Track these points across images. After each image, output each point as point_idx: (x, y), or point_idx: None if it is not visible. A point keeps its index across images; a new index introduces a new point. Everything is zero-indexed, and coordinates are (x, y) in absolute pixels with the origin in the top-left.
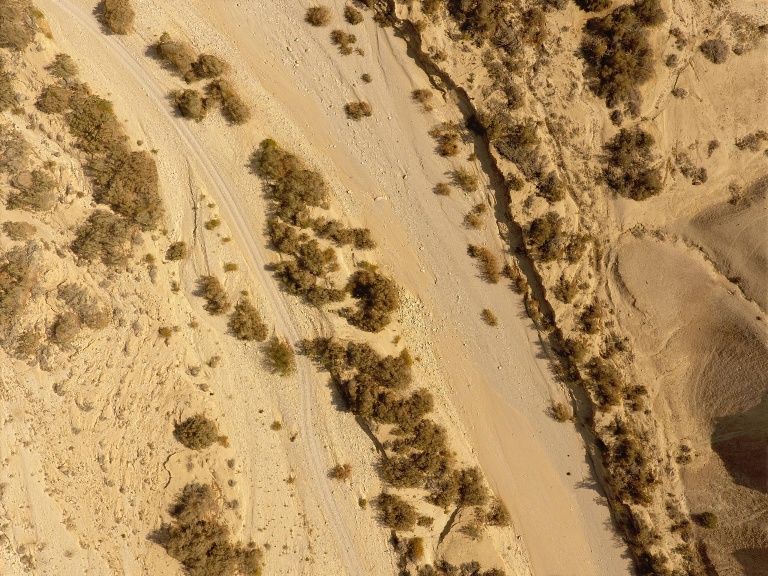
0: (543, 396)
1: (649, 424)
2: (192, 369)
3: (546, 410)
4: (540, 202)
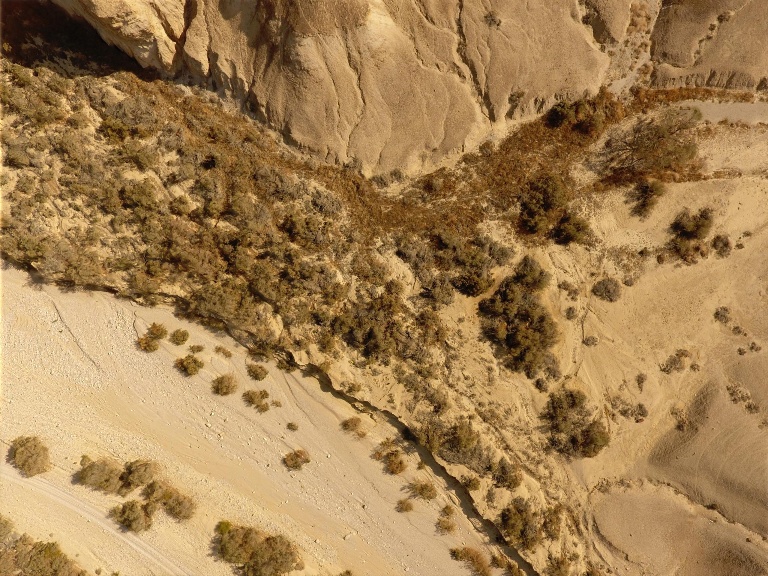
0: None
1: None
2: None
3: None
4: (501, 493)
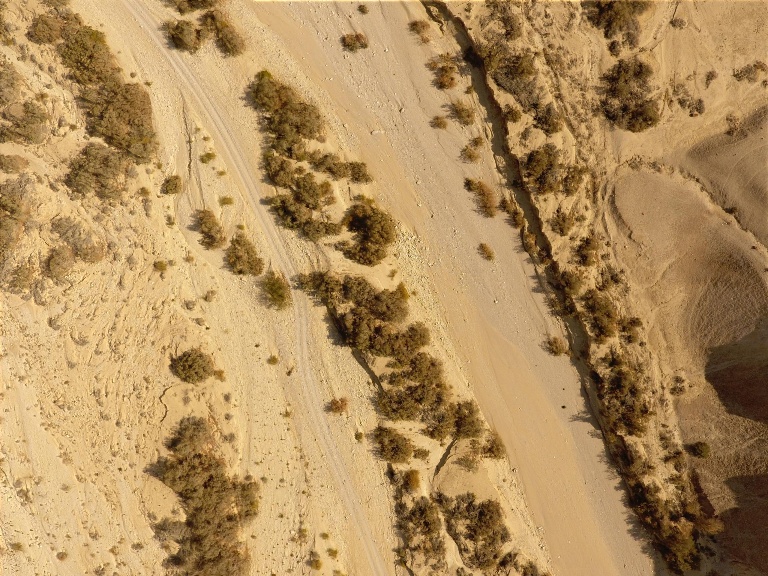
0: (539, 330)
1: (644, 356)
2: (188, 303)
3: (542, 344)
4: (537, 134)
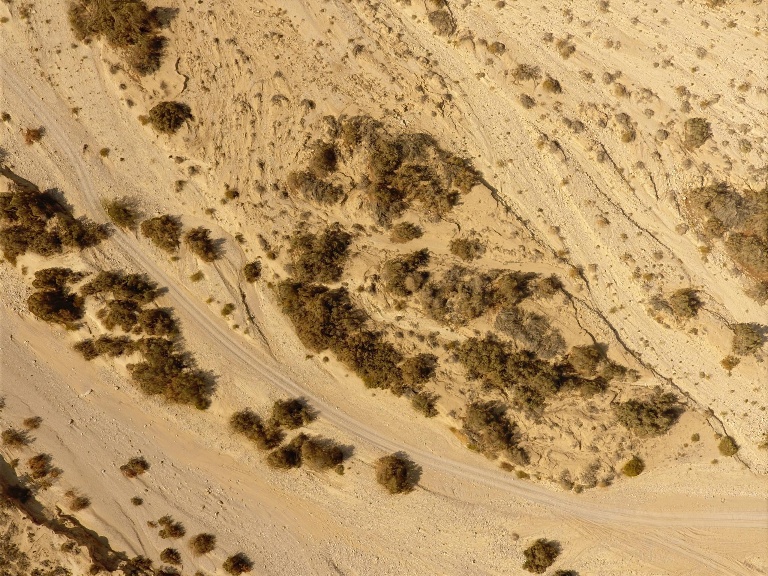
0: None
1: None
2: (194, 172)
3: None
4: None
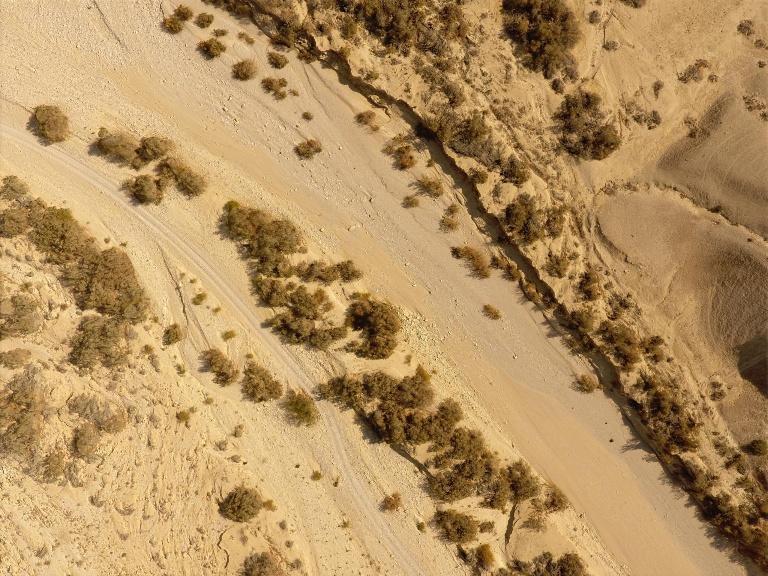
0: (565, 373)
1: (675, 371)
2: (219, 444)
3: (572, 385)
4: (508, 188)
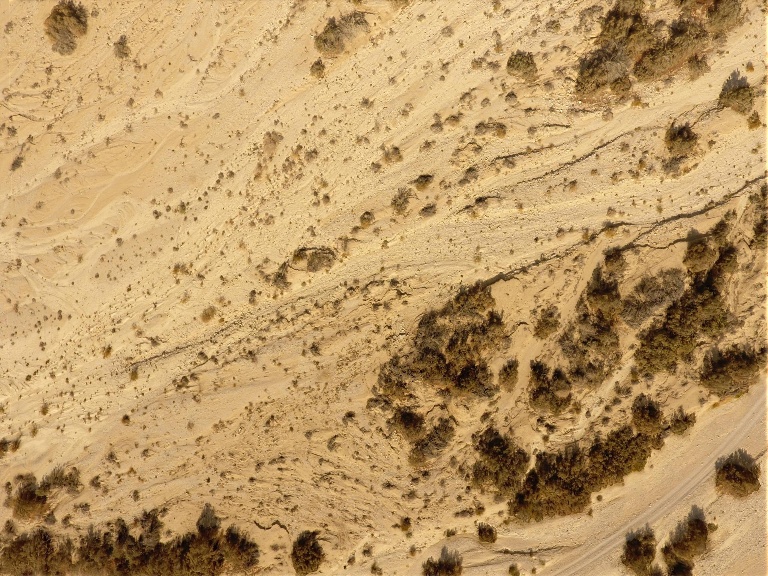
0: None
1: None
2: (370, 552)
3: None
4: None
